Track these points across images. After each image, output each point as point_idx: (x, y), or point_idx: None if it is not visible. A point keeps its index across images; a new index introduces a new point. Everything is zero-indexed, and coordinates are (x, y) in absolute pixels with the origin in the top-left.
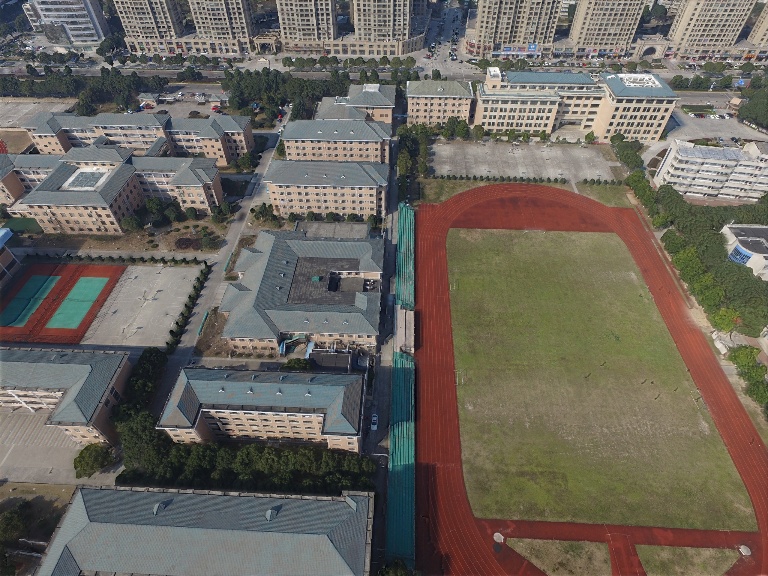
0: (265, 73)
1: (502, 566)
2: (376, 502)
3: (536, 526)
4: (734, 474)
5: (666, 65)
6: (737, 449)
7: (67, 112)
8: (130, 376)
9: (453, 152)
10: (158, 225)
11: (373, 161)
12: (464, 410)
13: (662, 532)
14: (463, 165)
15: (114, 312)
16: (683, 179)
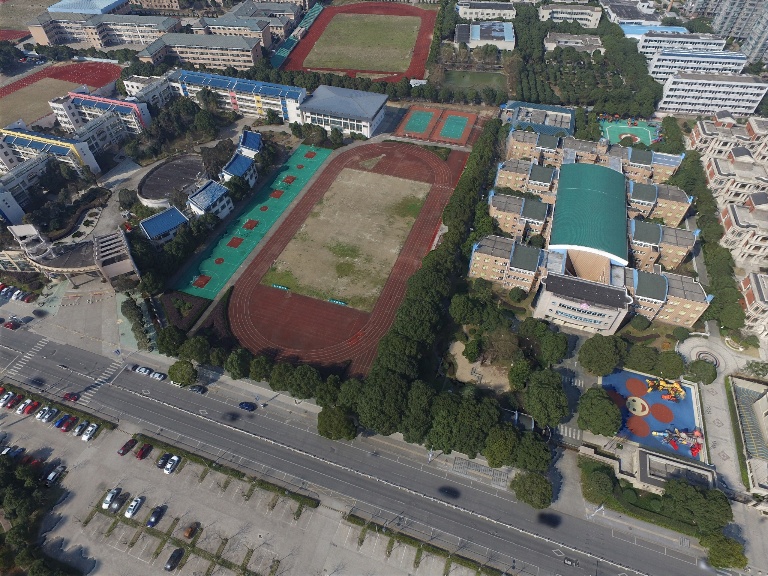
0: None
1: None
2: (265, 53)
3: None
4: (408, 64)
5: None
6: (415, 60)
7: None
8: None
9: None
10: (197, 7)
11: None
12: (313, 50)
13: (369, 71)
14: None
15: None
16: None
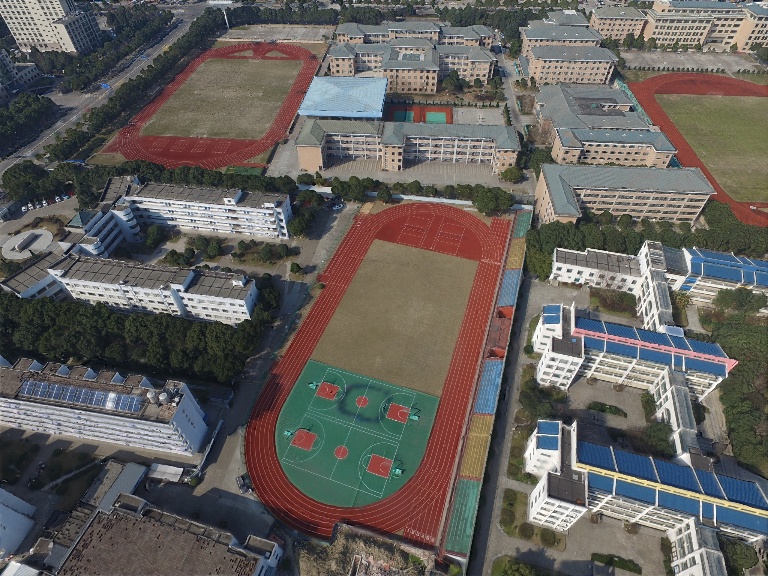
0: None
1: (760, 216)
2: None
3: None
4: None
5: None
6: None
7: None
8: None
9: (634, 56)
10: (457, 89)
11: None
12: (709, 166)
13: None
14: (645, 63)
15: None
16: None
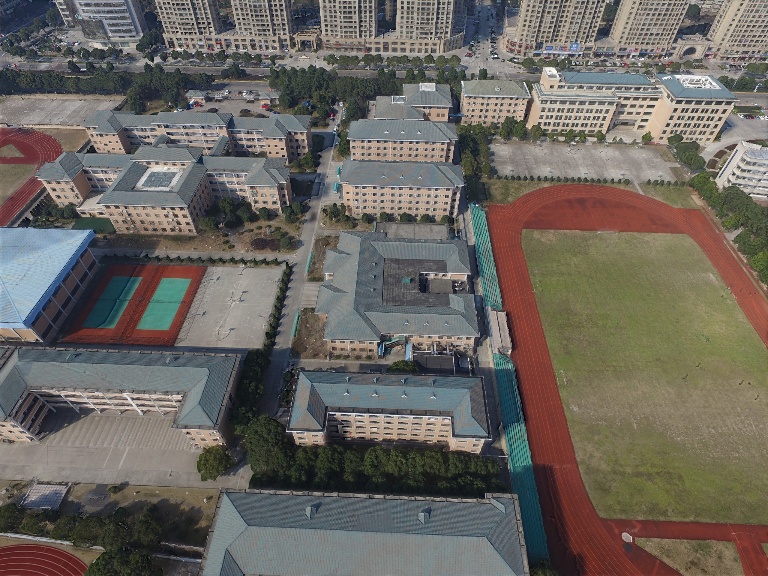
0: (311, 71)
1: (635, 565)
2: None
3: (662, 526)
4: None
5: (707, 65)
6: None
7: (117, 110)
8: (241, 379)
9: (512, 152)
10: (231, 225)
11: (439, 161)
12: (570, 411)
13: None
14: (524, 165)
15: (203, 313)
16: (749, 181)
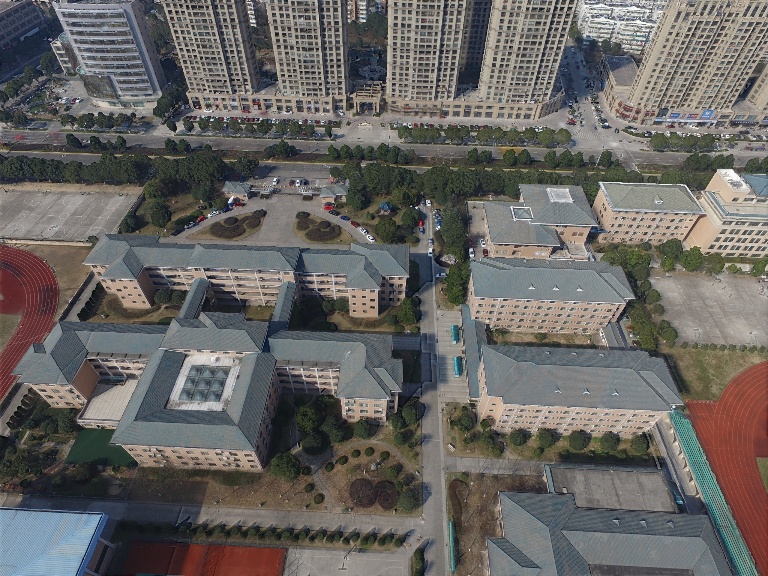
0: (383, 152)
1: None
2: None
3: None
4: None
5: None
6: None
7: (132, 215)
8: None
9: (684, 293)
10: (314, 452)
11: None
12: None
13: None
14: (710, 319)
15: None
16: None
